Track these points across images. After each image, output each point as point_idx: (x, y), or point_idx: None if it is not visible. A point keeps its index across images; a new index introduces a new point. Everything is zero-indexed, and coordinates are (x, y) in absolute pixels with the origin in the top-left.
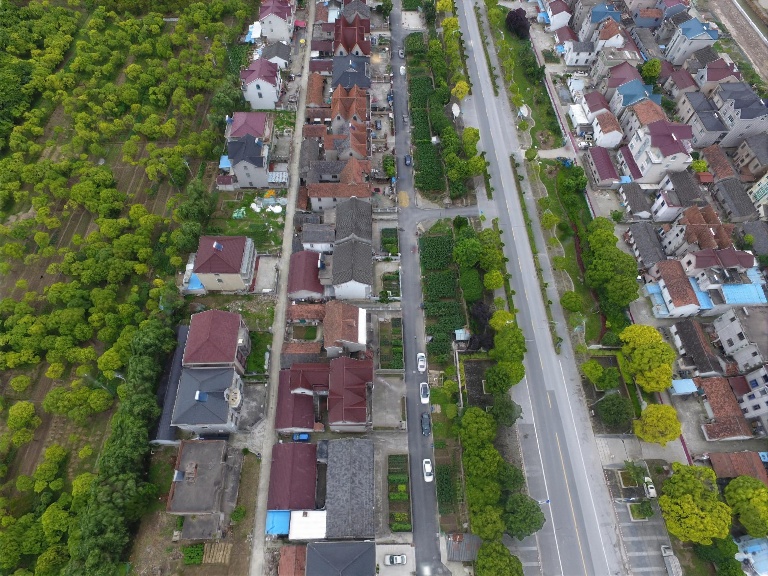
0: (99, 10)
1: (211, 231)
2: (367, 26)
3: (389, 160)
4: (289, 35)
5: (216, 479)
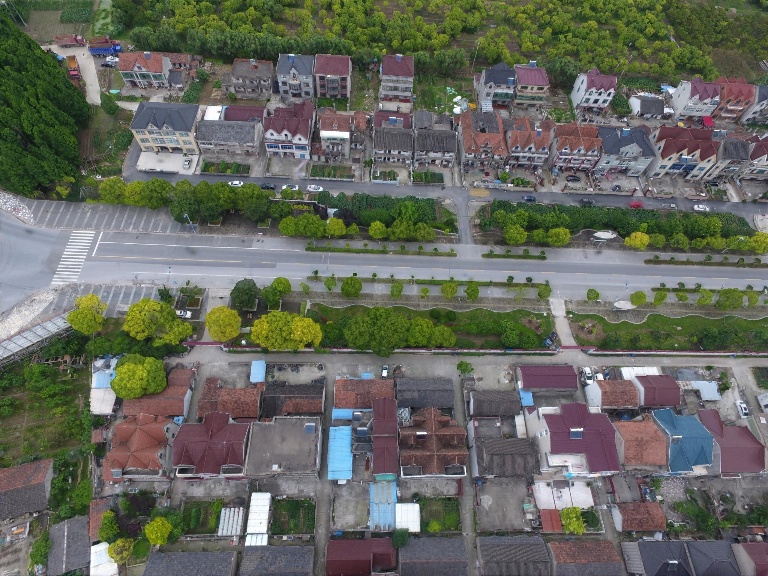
0: (661, 1)
1: (432, 77)
2: (708, 155)
3: (524, 182)
4: (682, 111)
5: (248, 76)
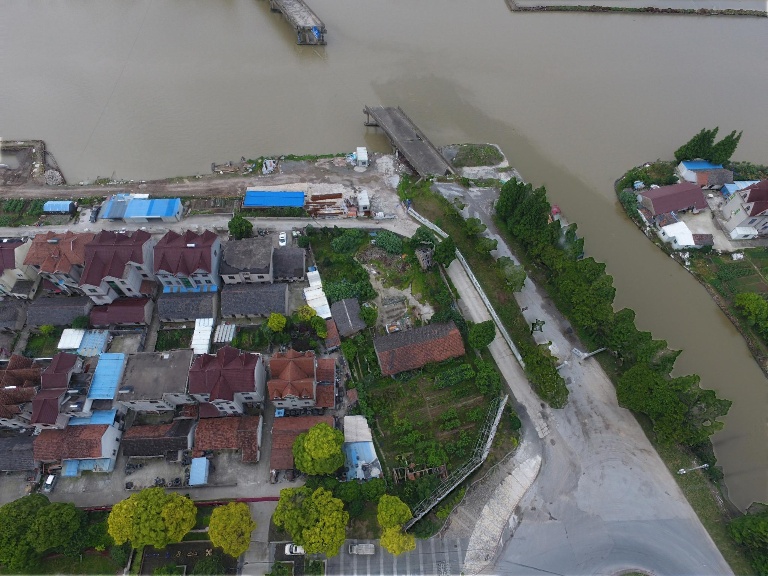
0: None
1: None
2: None
3: None
4: None
5: None
